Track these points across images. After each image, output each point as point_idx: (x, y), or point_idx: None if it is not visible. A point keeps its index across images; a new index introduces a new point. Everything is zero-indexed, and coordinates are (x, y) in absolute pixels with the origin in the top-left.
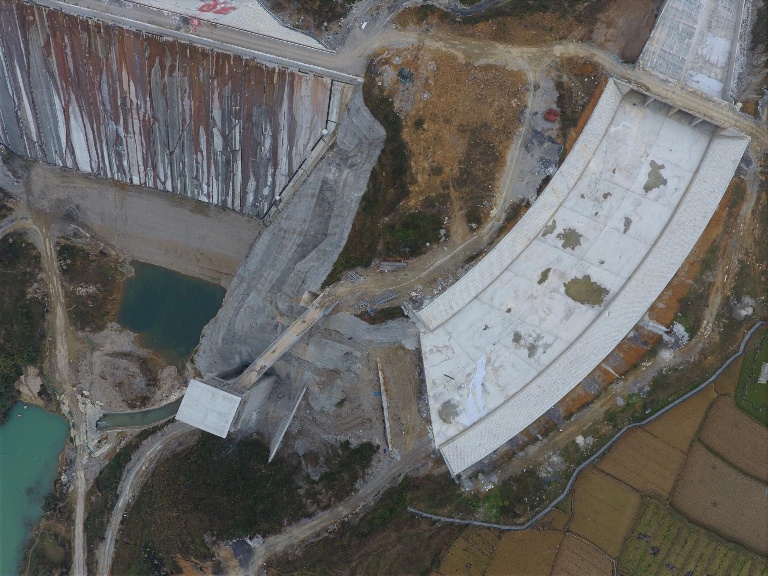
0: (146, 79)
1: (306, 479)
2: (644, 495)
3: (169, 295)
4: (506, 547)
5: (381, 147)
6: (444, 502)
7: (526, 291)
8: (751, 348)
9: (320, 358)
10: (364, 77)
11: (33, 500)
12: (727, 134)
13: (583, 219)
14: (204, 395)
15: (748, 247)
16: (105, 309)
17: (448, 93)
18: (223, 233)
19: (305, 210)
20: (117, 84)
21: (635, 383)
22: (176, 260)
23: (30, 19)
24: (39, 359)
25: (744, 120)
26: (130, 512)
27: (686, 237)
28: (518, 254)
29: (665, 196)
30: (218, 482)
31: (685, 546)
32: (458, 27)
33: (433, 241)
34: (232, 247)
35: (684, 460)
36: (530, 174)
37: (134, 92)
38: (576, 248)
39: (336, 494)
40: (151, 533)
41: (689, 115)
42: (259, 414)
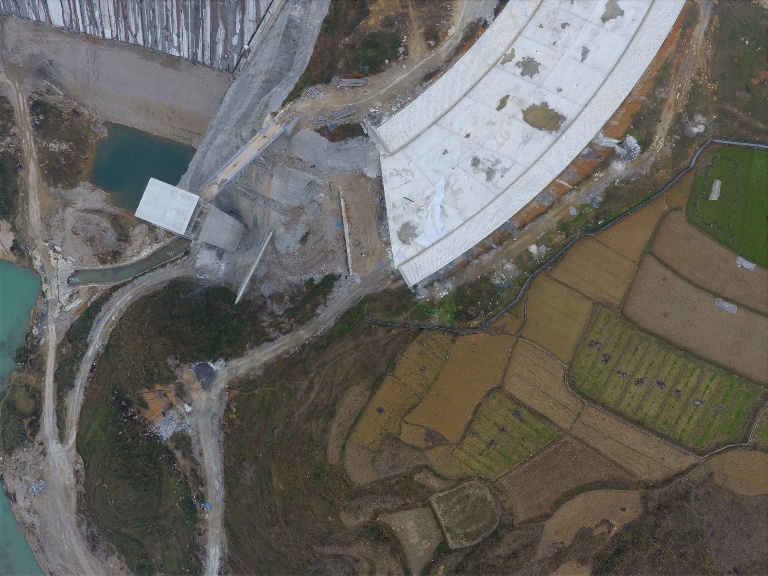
0: None
1: (270, 314)
2: (596, 304)
3: (141, 157)
4: (460, 351)
5: None
6: (400, 310)
7: (485, 117)
8: (703, 166)
9: (285, 193)
10: None
11: (5, 354)
12: None
13: (541, 48)
14: (163, 193)
15: (701, 67)
16: (78, 168)
17: None
18: (194, 88)
19: (271, 50)
20: None
21: (588, 193)
22: (148, 120)
23: None
24: (12, 214)
25: None
26: (99, 358)
27: (641, 60)
28: (477, 80)
29: (622, 26)
30: (183, 315)
31: (636, 353)
32: None
33: (392, 59)
34: (203, 103)
35: (635, 269)
36: None
37: None
38: (534, 76)
39: (298, 320)
40: (119, 375)
41: None
42: (228, 265)
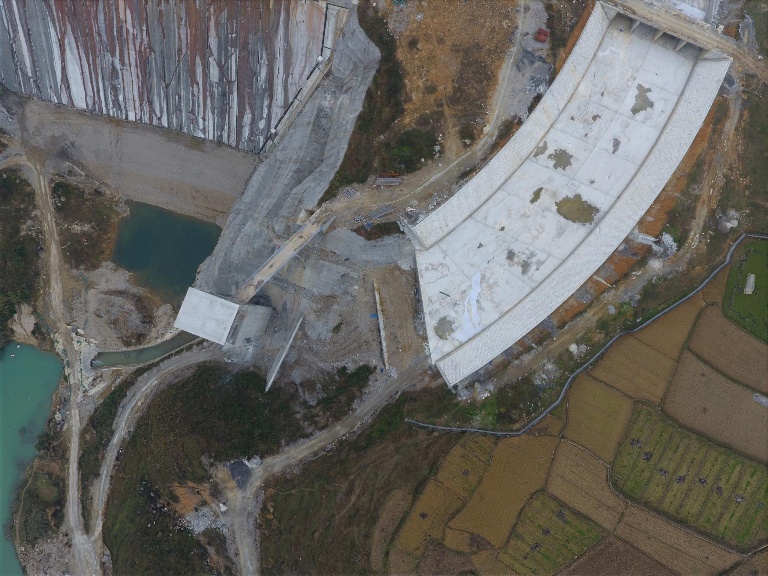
0: (142, 7)
1: (303, 404)
2: (636, 402)
3: (164, 235)
4: (503, 453)
5: (376, 68)
6: (441, 412)
7: (519, 210)
8: (737, 260)
9: (317, 283)
10: None
11: (26, 440)
12: (710, 57)
13: (573, 140)
14: (202, 303)
15: (732, 162)
16: (100, 248)
17: (441, 14)
18: (219, 169)
19: (301, 138)
20: (113, 13)
21: (626, 292)
22: (171, 199)
23: None
24: (33, 297)
25: (726, 42)
26: (126, 447)
27: (673, 154)
28: (511, 173)
29: (652, 118)
30: (215, 408)
31: (677, 451)
32: None
33: (428, 157)
34: (228, 183)
35: (675, 367)
36: (521, 92)
37: (130, 21)
38: (567, 168)
39: (334, 415)
40: (147, 465)
41: (673, 39)
42: (255, 348)
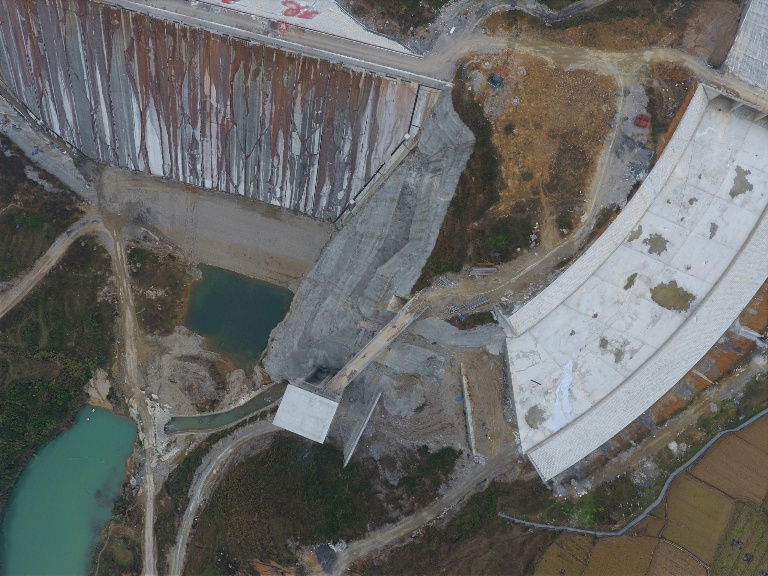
0: (228, 83)
1: (385, 484)
2: (737, 502)
3: (236, 298)
4: (600, 553)
5: (470, 152)
6: (536, 508)
7: (612, 296)
8: None
9: (400, 363)
10: (453, 82)
11: (101, 503)
12: None
13: (669, 224)
14: (301, 400)
15: None
16: (173, 312)
17: (538, 98)
18: (294, 237)
19: (384, 214)
20: (198, 88)
21: (729, 389)
22: (244, 264)
23: (115, 23)
24: (108, 362)
25: None
26: (202, 516)
27: None
28: (605, 259)
29: (751, 202)
30: (297, 487)
31: None
32: (548, 32)
33: (523, 246)
34: (302, 251)
35: None
36: (621, 179)
37: (215, 96)
38: (662, 253)
39: (419, 499)
40: (225, 537)
41: None
42: None
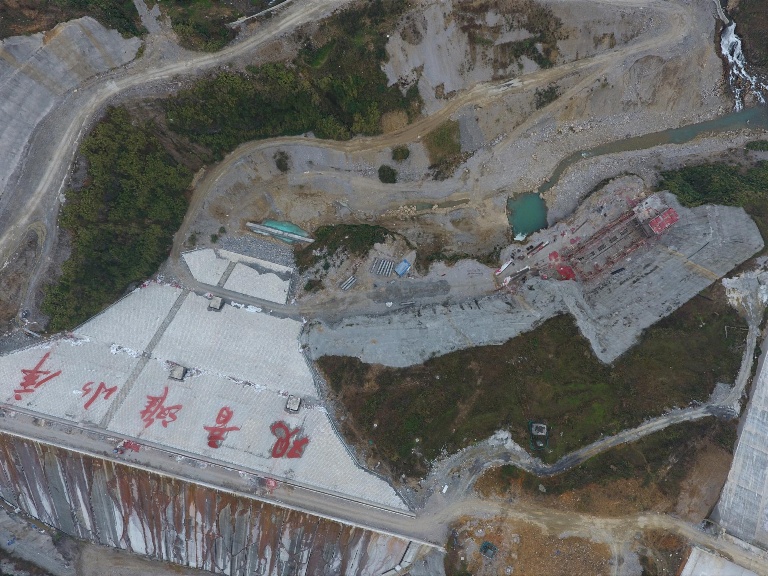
0: (214, 513)
1: None
2: None
3: None
4: None
5: None
6: None
7: None
8: None
9: None
10: (446, 548)
11: None
12: None
13: None
14: None
15: None
16: None
17: (532, 568)
18: None
19: None
20: (183, 512)
21: None
22: None
23: (97, 465)
24: None
25: None
26: None
27: None
28: None
29: None
30: None
31: None
32: (542, 499)
33: None
34: None
35: None
36: None
37: (200, 518)
38: None
39: None
40: None
41: None
42: None
